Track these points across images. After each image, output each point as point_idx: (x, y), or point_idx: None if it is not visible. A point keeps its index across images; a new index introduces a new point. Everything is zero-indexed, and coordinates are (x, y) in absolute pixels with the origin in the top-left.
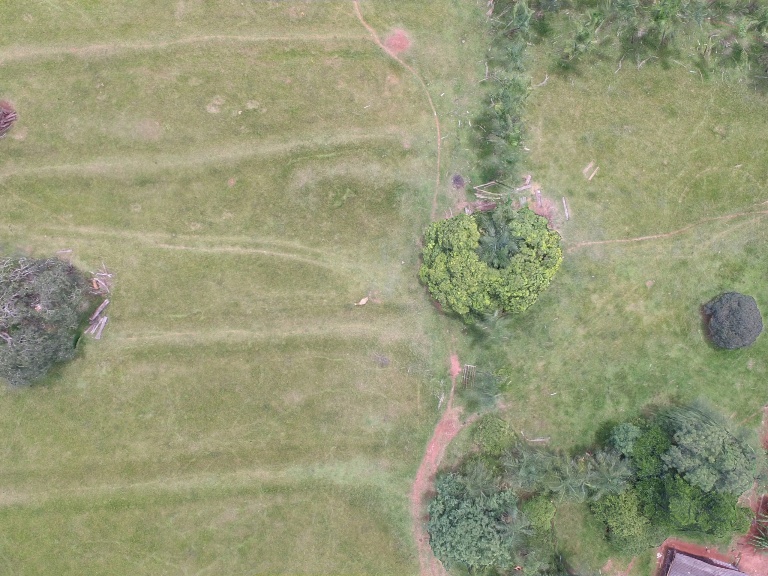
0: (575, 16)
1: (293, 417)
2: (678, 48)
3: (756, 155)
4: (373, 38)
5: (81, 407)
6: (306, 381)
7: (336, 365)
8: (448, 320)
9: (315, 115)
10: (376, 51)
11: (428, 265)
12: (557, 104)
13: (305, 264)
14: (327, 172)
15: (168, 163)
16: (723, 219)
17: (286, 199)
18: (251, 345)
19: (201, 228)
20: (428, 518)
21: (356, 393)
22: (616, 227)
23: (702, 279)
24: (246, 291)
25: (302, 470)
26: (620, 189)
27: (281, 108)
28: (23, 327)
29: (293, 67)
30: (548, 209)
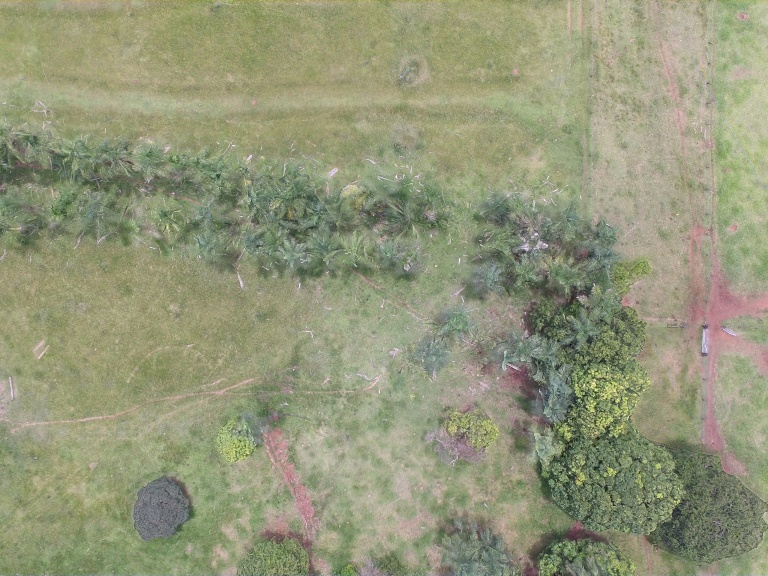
0: (39, 190)
1: None
2: (140, 223)
3: (209, 334)
4: None
5: None
6: None
7: None
8: None
9: None
10: None
11: None
12: (13, 280)
13: None
14: None
15: None
16: (171, 400)
17: None
18: None
19: None
20: None
21: None
22: (61, 408)
23: (145, 462)
24: None
25: None
26: (70, 368)
27: None
28: None
29: None
30: None
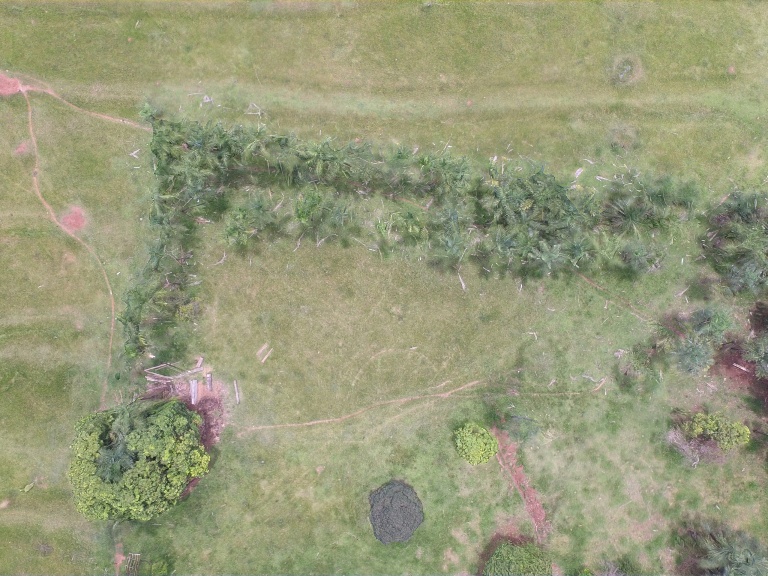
0: (256, 192)
1: None
2: (359, 225)
3: (432, 337)
4: (49, 216)
5: None
6: None
7: None
8: None
9: None
10: (52, 229)
11: None
12: (234, 283)
13: None
14: None
15: None
16: (397, 403)
17: None
18: None
19: None
20: None
21: None
22: (287, 411)
23: (373, 465)
24: None
25: None
26: (294, 371)
27: None
28: None
29: None
30: (219, 392)
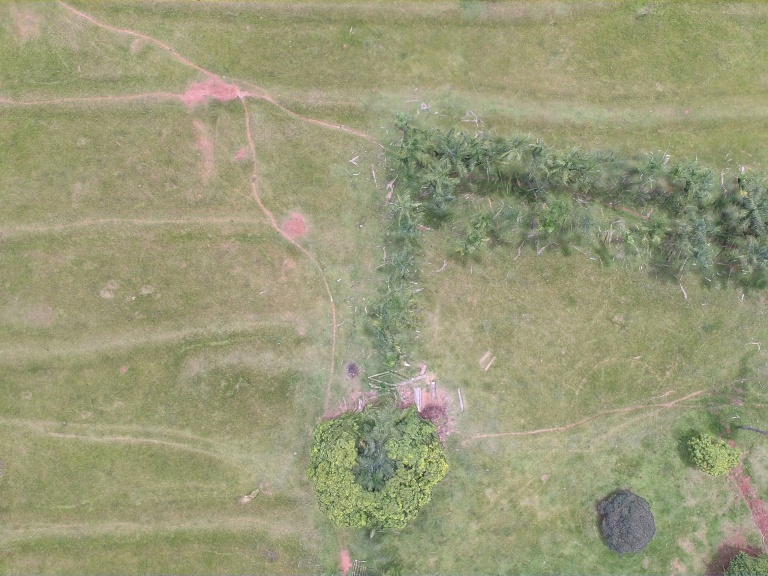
0: (475, 200)
1: None
2: (579, 234)
3: (655, 346)
4: (270, 222)
5: None
6: (194, 575)
7: (225, 559)
8: None
9: (210, 301)
10: (273, 235)
11: (315, 466)
12: (455, 291)
13: (196, 455)
14: (220, 361)
15: (60, 350)
16: (621, 412)
17: (178, 388)
18: (139, 538)
19: (92, 416)
20: None
21: None
22: (512, 420)
23: (598, 474)
24: (136, 482)
25: None
26: (517, 380)
27: (175, 294)
28: None
29: (189, 251)
30: (443, 400)
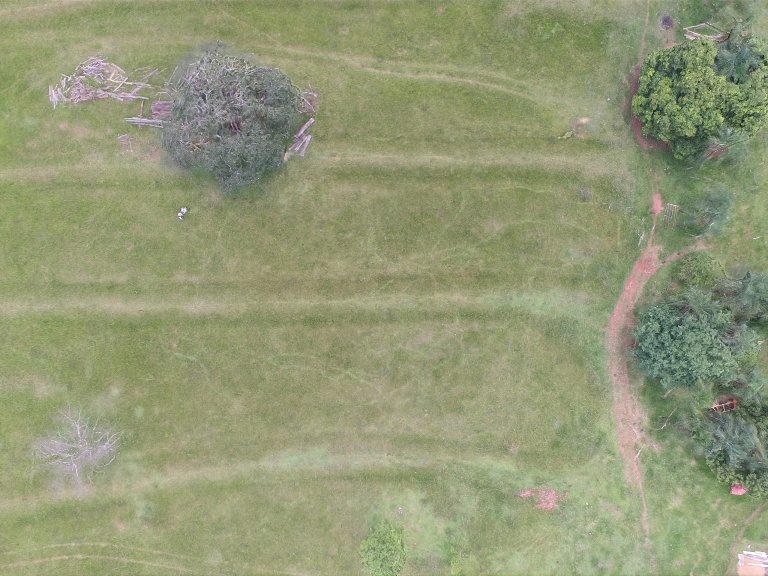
0: None
1: (492, 245)
2: None
3: None
4: None
5: (282, 222)
6: (507, 210)
7: (538, 196)
8: (652, 159)
9: None
10: None
11: (644, 95)
12: None
13: (511, 95)
14: (537, 5)
15: None
16: None
17: (494, 30)
18: (453, 172)
19: (408, 54)
20: (624, 353)
21: (557, 225)
22: None
23: None
24: (450, 119)
25: (500, 297)
26: None
27: None
28: (251, 121)
29: None
30: None
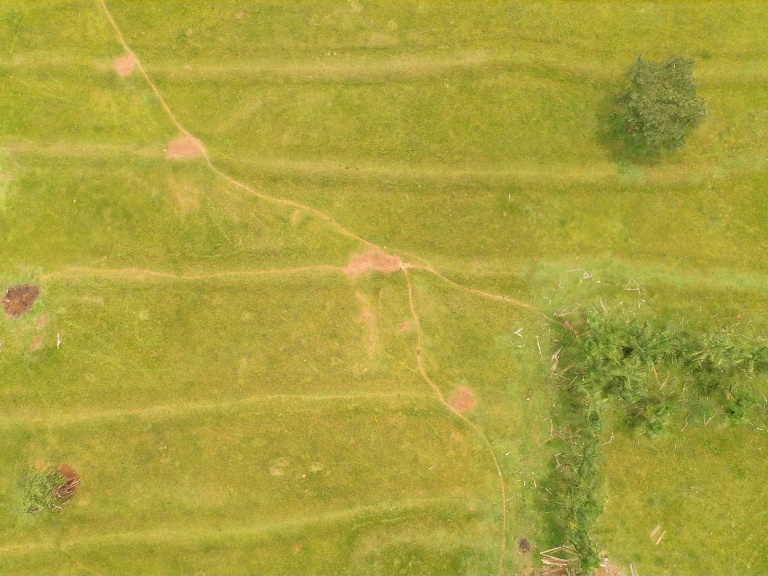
0: None
1: None
2: None
3: None
4: (437, 396)
5: None
6: None
7: None
8: None
9: (379, 477)
10: (440, 409)
11: None
12: (623, 463)
13: None
14: (392, 539)
15: (232, 530)
16: None
17: (351, 567)
18: None
19: None
20: None
21: None
22: None
23: None
24: None
25: None
26: (688, 553)
27: (345, 470)
28: None
29: (357, 427)
30: (615, 575)
